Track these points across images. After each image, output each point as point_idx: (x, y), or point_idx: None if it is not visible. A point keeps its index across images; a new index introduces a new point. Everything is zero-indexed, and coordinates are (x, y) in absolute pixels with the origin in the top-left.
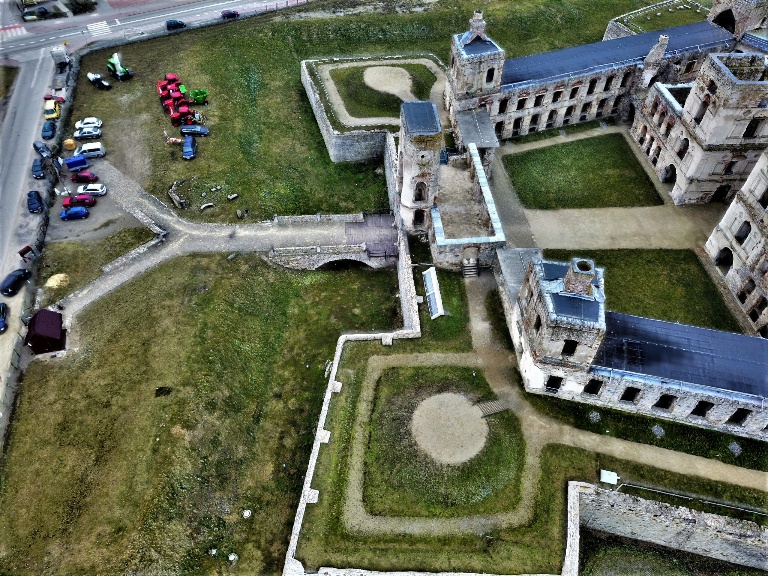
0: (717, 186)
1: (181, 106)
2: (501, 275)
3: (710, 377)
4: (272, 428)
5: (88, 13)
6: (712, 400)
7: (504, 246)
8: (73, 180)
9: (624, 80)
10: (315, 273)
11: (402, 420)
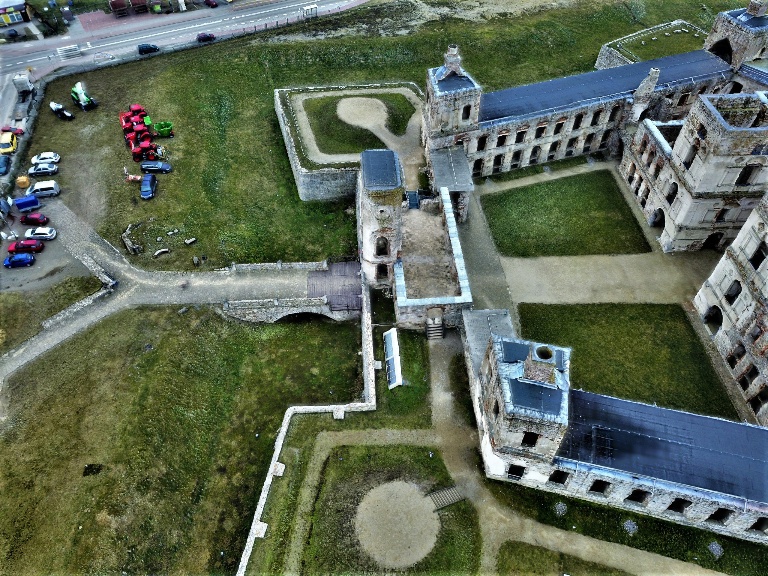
0: (708, 234)
1: (144, 139)
2: (467, 339)
3: (687, 473)
4: (212, 508)
5: (59, 36)
6: (689, 499)
7: (471, 307)
8: (22, 222)
9: (613, 114)
10: (274, 326)
11: (346, 513)
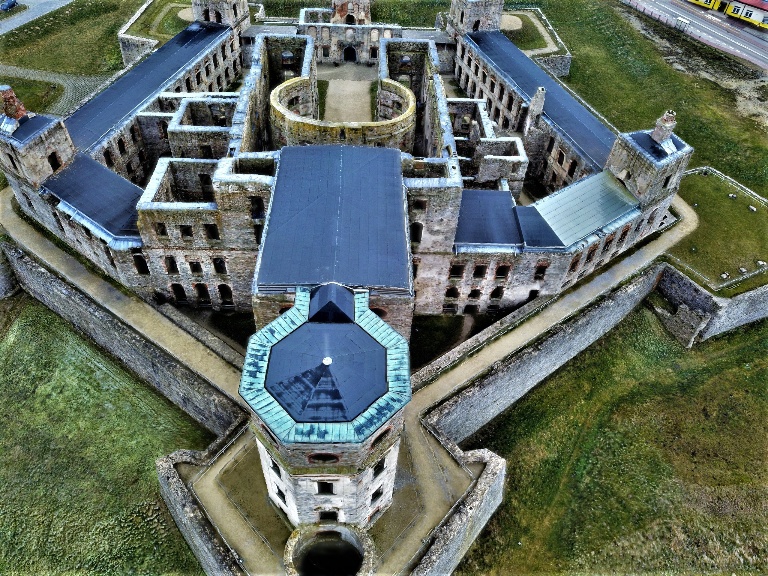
0: None
1: None
2: None
3: None
4: None
5: None
6: None
7: None
8: None
9: None
10: None
11: None
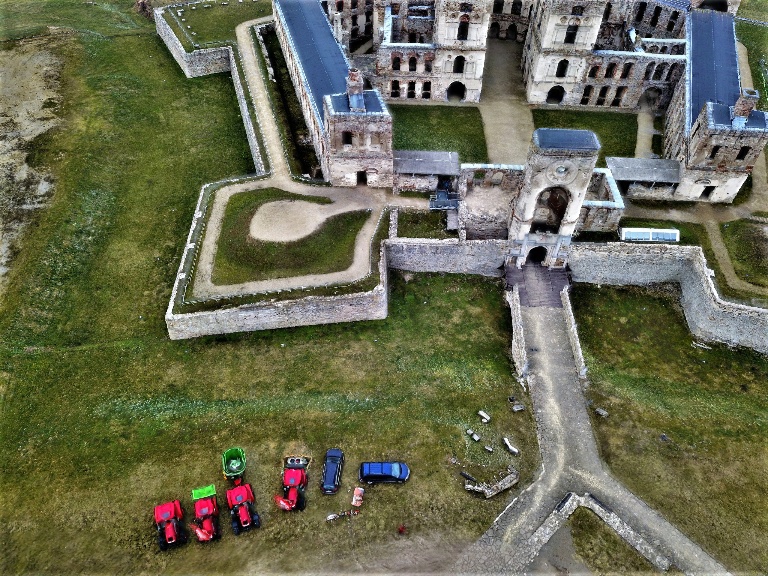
0: None
1: None
2: (631, 187)
3: None
4: None
5: None
6: None
7: None
8: None
9: None
10: None
11: None
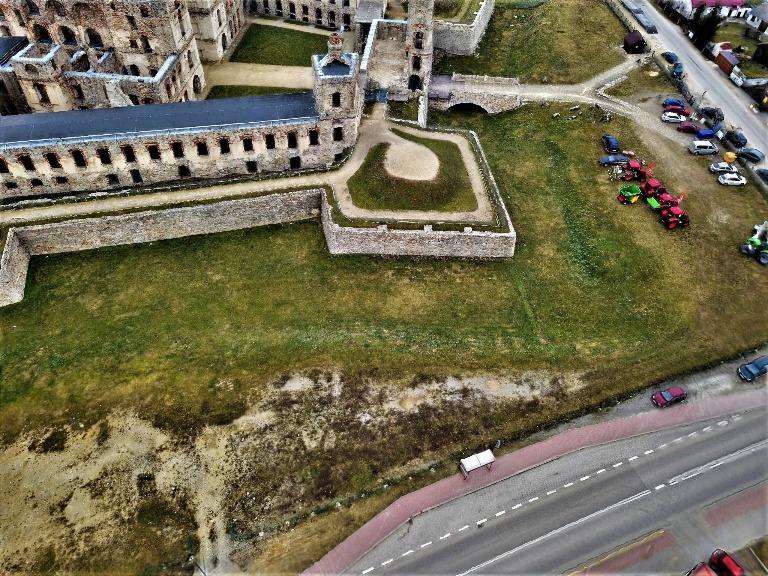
0: None
1: None
2: None
3: None
4: None
5: None
6: None
7: None
8: None
9: None
10: None
11: None
